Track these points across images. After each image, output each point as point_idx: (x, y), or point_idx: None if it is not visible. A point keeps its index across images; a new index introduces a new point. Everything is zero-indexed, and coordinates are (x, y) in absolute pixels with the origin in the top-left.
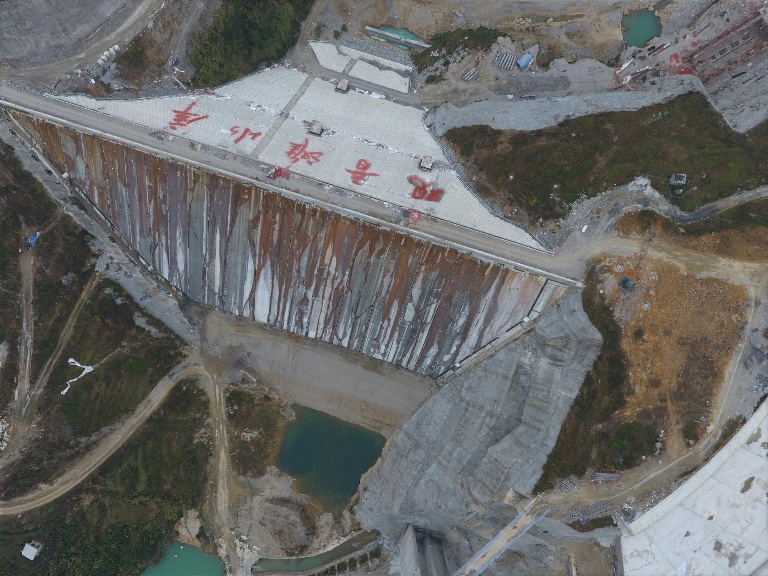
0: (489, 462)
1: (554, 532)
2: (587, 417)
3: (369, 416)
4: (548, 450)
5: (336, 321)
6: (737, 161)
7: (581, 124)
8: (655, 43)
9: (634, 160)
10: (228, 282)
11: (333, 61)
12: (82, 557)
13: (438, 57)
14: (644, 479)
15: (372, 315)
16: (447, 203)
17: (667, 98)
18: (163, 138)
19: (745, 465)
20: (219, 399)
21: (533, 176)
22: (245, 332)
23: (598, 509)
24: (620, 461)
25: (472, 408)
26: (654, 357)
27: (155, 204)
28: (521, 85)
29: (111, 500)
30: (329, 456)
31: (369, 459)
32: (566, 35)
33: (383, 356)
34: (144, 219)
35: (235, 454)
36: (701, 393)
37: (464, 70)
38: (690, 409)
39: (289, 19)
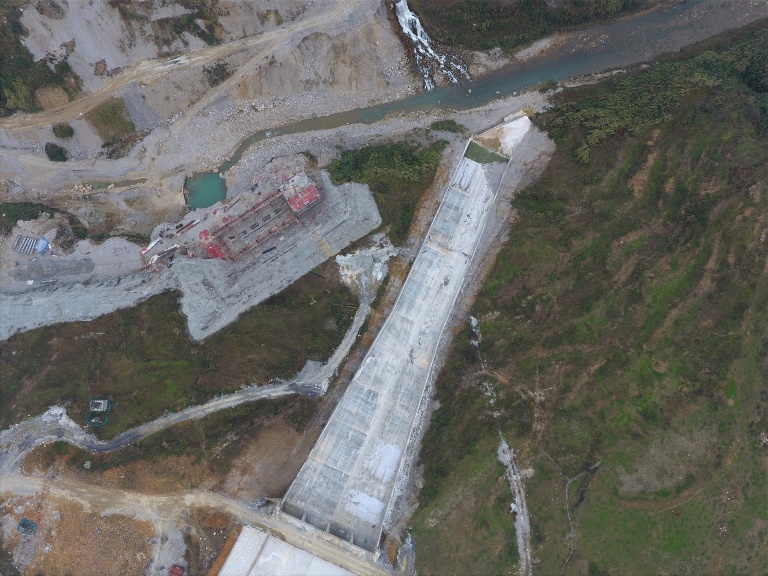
0: None
1: None
2: None
3: None
4: None
5: None
6: (175, 377)
7: (25, 340)
8: (185, 220)
9: (58, 385)
10: None
11: None
12: None
13: None
14: None
15: None
16: None
17: (140, 299)
18: None
19: None
20: None
21: None
22: None
23: None
24: None
25: None
26: None
27: None
28: (42, 270)
29: None
30: None
31: None
32: (125, 202)
33: None
34: None
35: None
36: None
37: None
38: None
39: None
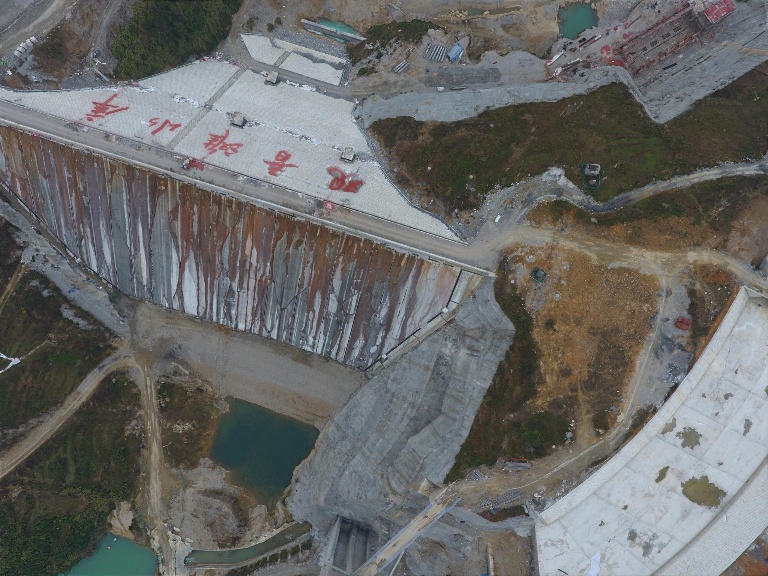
0: (408, 452)
1: (470, 522)
2: (499, 407)
3: (302, 408)
4: (462, 440)
5: (263, 313)
6: (654, 151)
7: (500, 115)
8: (586, 35)
9: (549, 150)
10: (155, 274)
11: (265, 54)
12: (9, 548)
13: (372, 50)
14: (555, 468)
15: (297, 307)
16: (364, 194)
17: (589, 89)
18: (78, 129)
19: (660, 455)
20: (150, 391)
21: (450, 167)
22: (175, 324)
23: (508, 498)
24: (531, 450)
25: (396, 399)
26: (565, 347)
27: (76, 196)
28: (452, 77)
29: (40, 492)
30: (263, 448)
31: (303, 451)
32: (502, 28)
33: (312, 348)
34: (67, 211)
35: (167, 446)
36: (612, 383)
37: (395, 62)
38: (601, 399)
39: (218, 11)
